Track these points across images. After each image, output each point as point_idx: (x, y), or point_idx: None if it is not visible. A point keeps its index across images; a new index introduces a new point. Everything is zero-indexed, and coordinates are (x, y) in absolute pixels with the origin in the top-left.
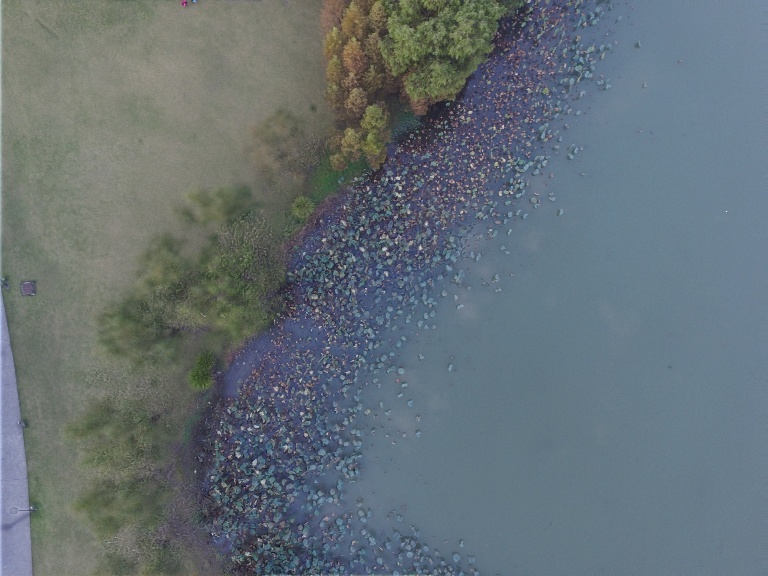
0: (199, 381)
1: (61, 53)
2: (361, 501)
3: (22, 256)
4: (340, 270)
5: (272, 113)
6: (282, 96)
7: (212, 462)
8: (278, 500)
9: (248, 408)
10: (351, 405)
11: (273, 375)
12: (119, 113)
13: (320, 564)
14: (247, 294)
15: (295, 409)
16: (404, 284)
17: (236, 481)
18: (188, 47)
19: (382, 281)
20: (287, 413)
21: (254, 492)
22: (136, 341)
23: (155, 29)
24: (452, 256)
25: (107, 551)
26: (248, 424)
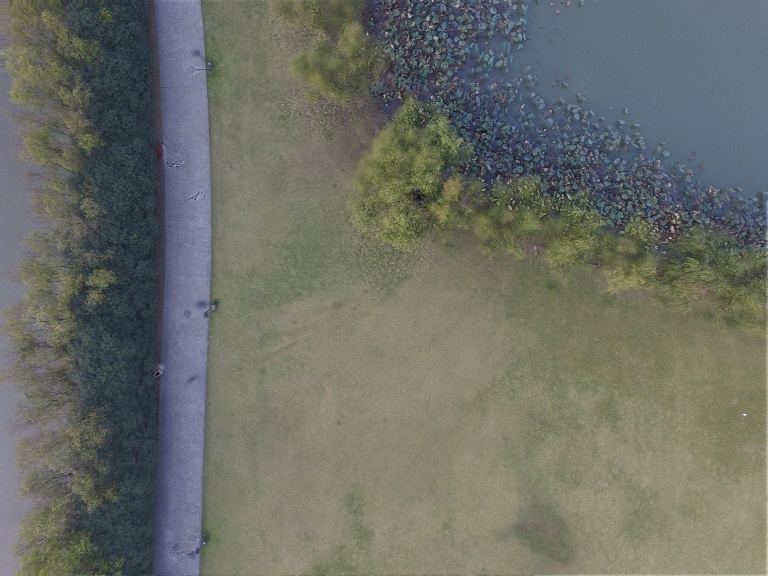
0: None
1: None
2: (530, 65)
3: None
4: None
5: None
6: None
7: (384, 24)
8: (451, 56)
9: None
10: None
11: None
12: None
13: (493, 120)
14: None
15: None
16: None
17: (409, 39)
18: None
19: None
20: None
21: (429, 46)
22: None
23: None
24: None
25: (281, 113)
26: None
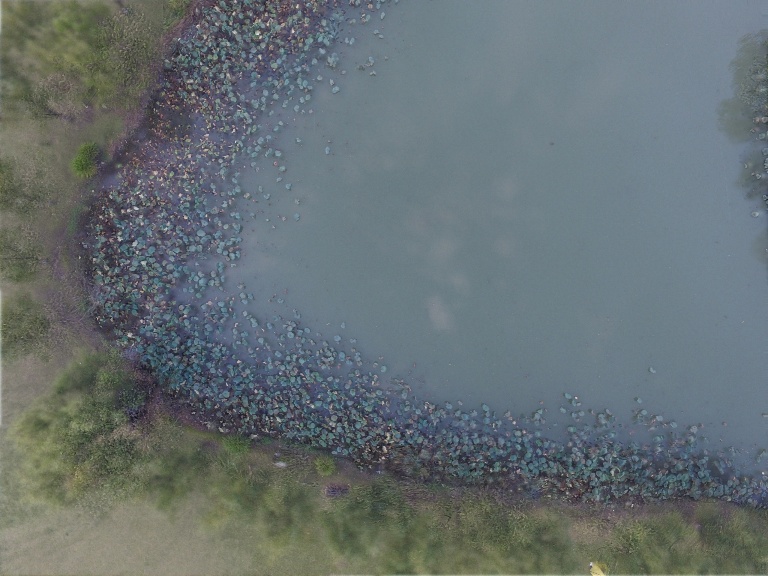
0: (83, 171)
1: None
2: (243, 284)
3: None
4: (214, 53)
5: None
6: None
7: (95, 247)
8: (159, 280)
9: (129, 193)
10: (230, 188)
11: (153, 160)
12: None
13: (202, 343)
14: (127, 84)
15: (173, 190)
16: (277, 66)
17: (118, 263)
18: None
19: (256, 64)
20: (166, 194)
21: (134, 272)
22: (21, 133)
23: None
24: (325, 39)
25: None
26: (128, 206)
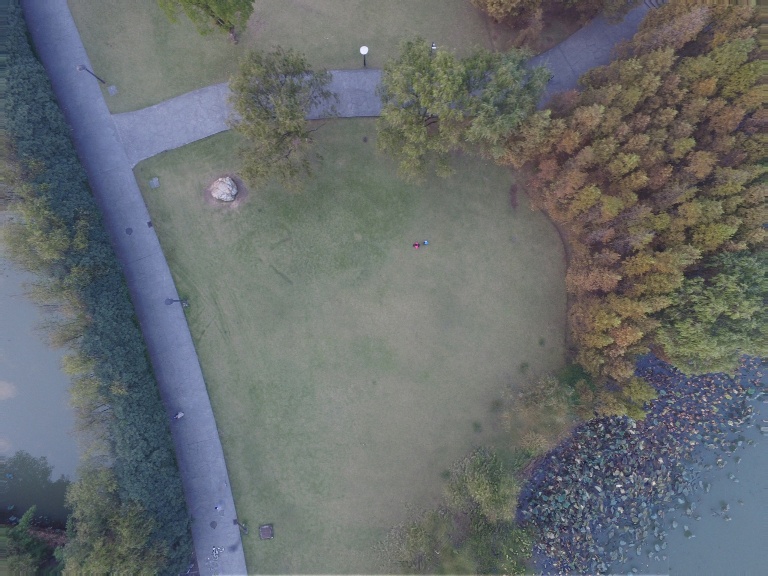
0: None
1: (295, 298)
2: None
3: (259, 499)
4: (577, 510)
5: (502, 349)
6: (511, 332)
7: None
8: None
9: None
10: None
11: None
12: (353, 355)
13: None
14: (480, 530)
15: None
16: (638, 520)
17: None
18: (419, 288)
19: (617, 518)
20: None
21: None
22: None
23: (387, 272)
24: (684, 489)
25: None
26: None
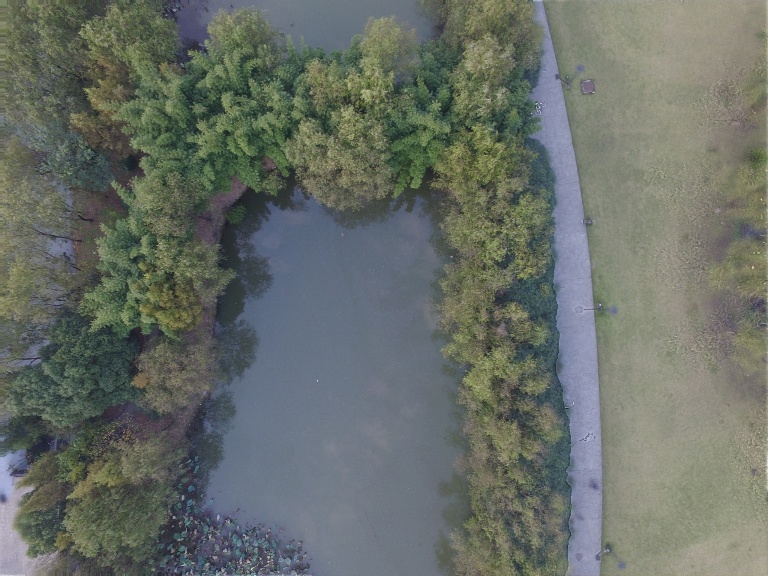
0: (749, 179)
1: None
2: None
3: (580, 55)
4: None
5: None
6: None
7: None
8: None
9: None
10: None
11: None
12: None
13: None
14: None
15: None
16: None
17: None
18: None
19: None
20: None
21: None
22: (690, 139)
23: None
24: None
25: (668, 350)
26: None
